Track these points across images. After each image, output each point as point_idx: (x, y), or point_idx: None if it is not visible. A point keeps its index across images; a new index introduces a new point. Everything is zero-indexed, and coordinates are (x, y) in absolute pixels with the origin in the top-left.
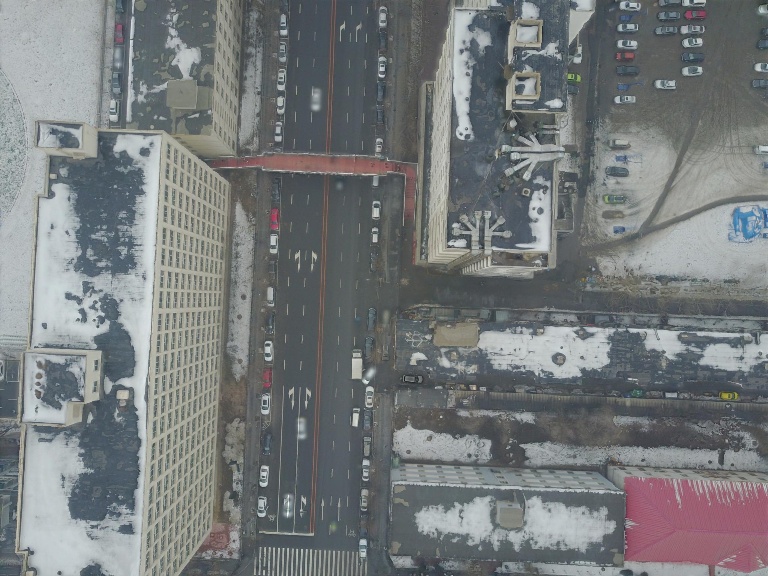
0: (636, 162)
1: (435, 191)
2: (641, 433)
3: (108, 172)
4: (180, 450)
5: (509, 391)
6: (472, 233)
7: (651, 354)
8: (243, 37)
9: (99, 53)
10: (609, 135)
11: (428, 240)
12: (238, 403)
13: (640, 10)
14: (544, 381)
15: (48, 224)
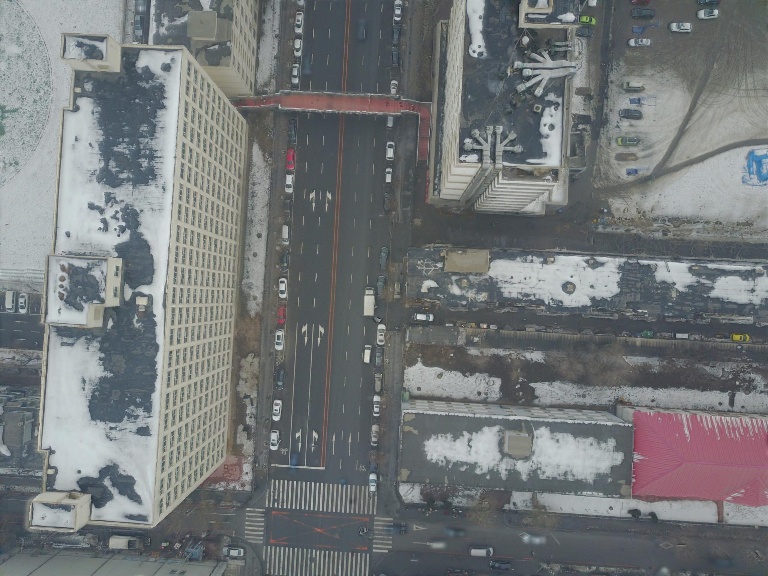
0: (650, 105)
1: (448, 121)
2: (651, 374)
3: (130, 87)
4: (196, 368)
5: (519, 330)
6: (483, 148)
7: (661, 286)
8: None
9: None
10: (623, 78)
11: (441, 176)
12: (252, 339)
13: None
14: (554, 310)
15: (72, 136)
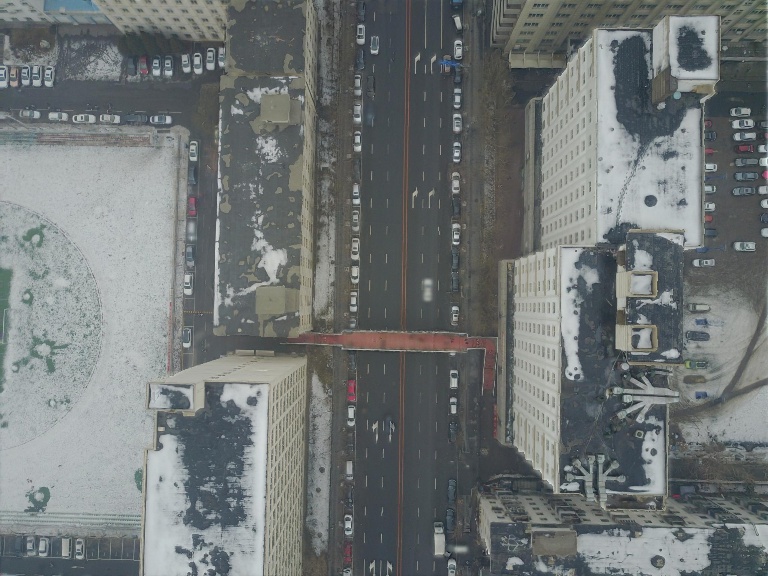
0: (717, 325)
1: (528, 392)
2: None
3: (215, 422)
4: None
5: None
6: (585, 478)
7: (750, 550)
8: (315, 206)
9: (172, 227)
10: (688, 298)
11: (513, 423)
12: None
13: (717, 171)
14: None
15: (156, 476)
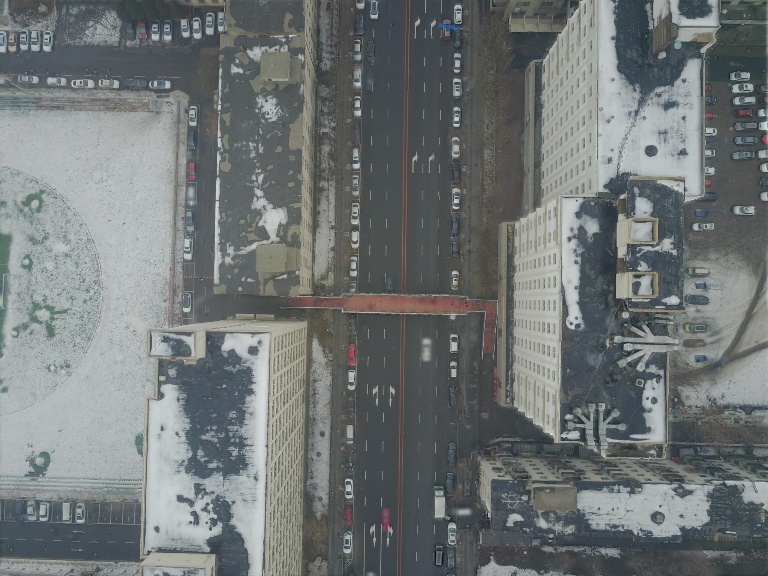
0: (716, 289)
1: (528, 350)
2: (729, 566)
3: (216, 371)
4: None
5: None
6: (586, 426)
7: (749, 507)
8: (315, 171)
9: (172, 192)
10: (688, 262)
11: (513, 384)
12: (319, 541)
13: (716, 135)
14: (643, 540)
15: (158, 426)
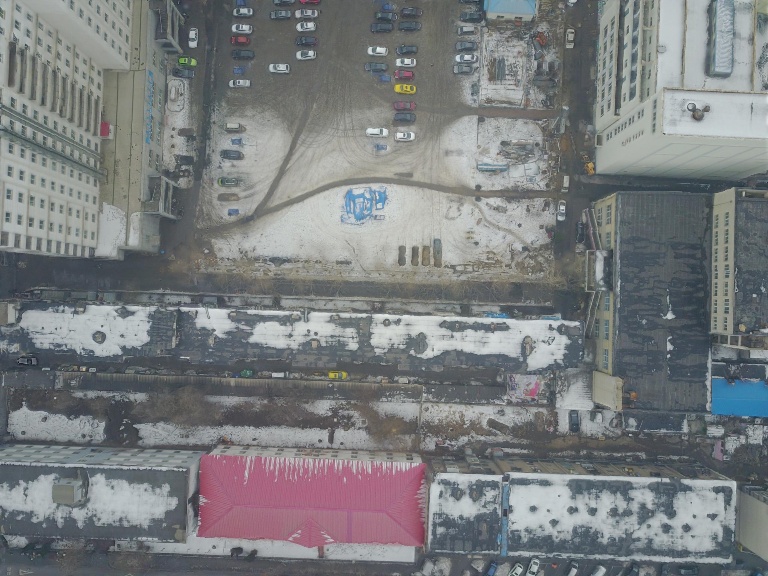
0: (251, 145)
1: None
2: (253, 413)
3: None
4: None
5: (117, 372)
6: None
7: (201, 332)
8: None
9: None
10: (225, 119)
11: None
12: None
13: None
14: (86, 359)
15: None
